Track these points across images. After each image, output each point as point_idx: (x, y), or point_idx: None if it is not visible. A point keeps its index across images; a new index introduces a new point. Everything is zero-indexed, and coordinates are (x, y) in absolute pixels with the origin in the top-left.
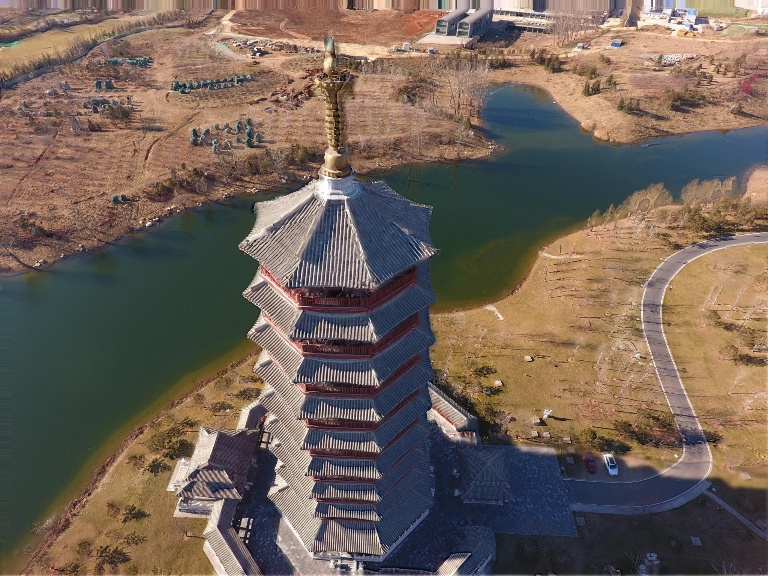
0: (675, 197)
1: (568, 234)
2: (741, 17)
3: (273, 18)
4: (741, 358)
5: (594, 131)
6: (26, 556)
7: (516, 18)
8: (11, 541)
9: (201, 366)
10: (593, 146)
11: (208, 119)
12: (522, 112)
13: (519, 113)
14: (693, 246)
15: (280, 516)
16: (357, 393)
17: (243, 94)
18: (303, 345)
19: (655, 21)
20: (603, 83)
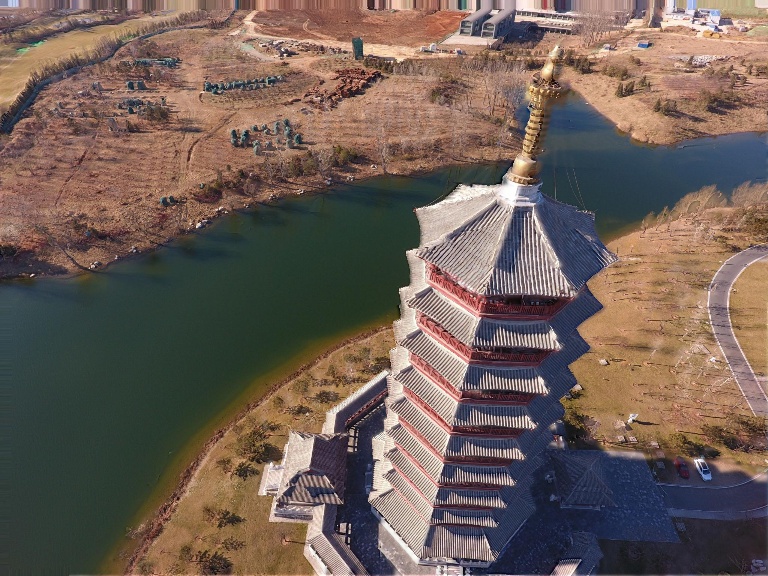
0: (722, 199)
1: (620, 236)
2: (765, 18)
3: (295, 18)
4: None
5: (631, 132)
6: (123, 561)
7: (538, 19)
8: (105, 546)
9: (271, 369)
10: (632, 148)
11: (245, 120)
12: (556, 113)
13: (553, 114)
14: (751, 249)
15: (378, 521)
16: (512, 400)
17: (276, 95)
18: (473, 352)
19: (678, 22)
20: (636, 84)
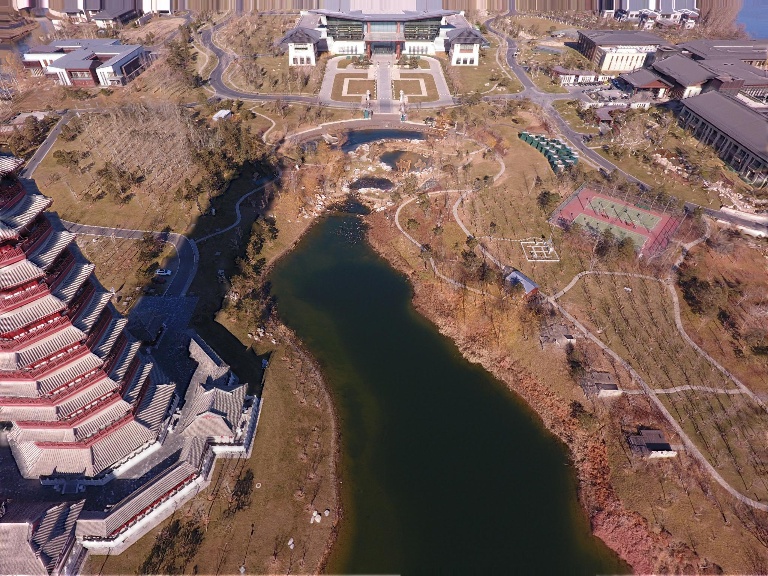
0: None
1: None
2: None
3: None
4: (125, 200)
5: None
6: None
7: None
8: None
9: None
10: None
11: None
12: None
13: None
14: None
15: (115, 479)
16: (69, 264)
17: None
18: (20, 246)
19: None
20: None
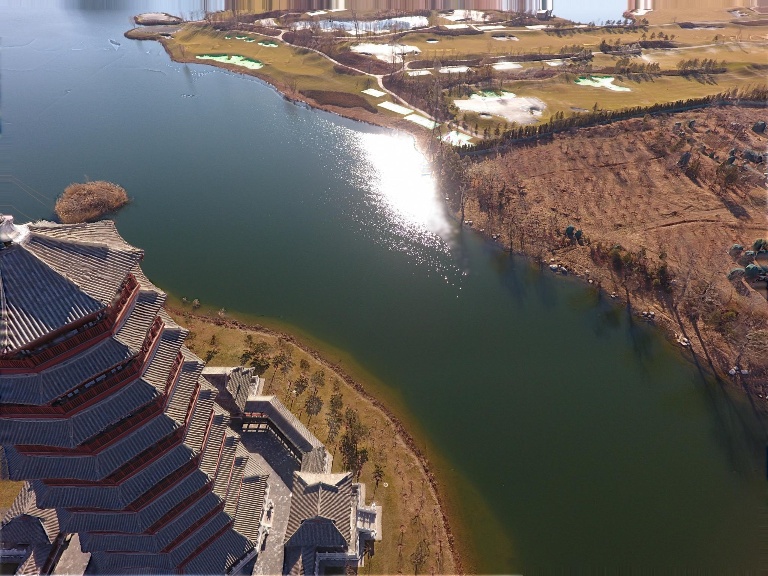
0: None
1: None
2: None
3: None
4: None
5: None
6: (206, 313)
7: None
8: (220, 304)
9: (360, 362)
10: None
11: None
12: None
13: None
14: None
15: None
16: None
17: None
18: None
19: None
20: None
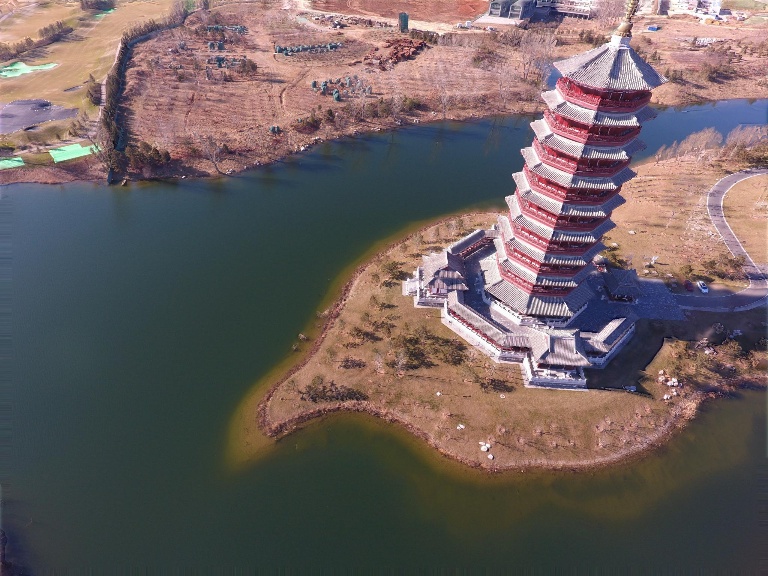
0: (718, 144)
1: (639, 165)
2: (760, 10)
3: None
4: None
5: None
6: (319, 328)
7: (557, 5)
8: (302, 322)
9: (386, 237)
10: None
11: (319, 75)
12: None
13: None
14: (740, 172)
15: (489, 306)
16: (604, 173)
17: (340, 57)
18: (589, 135)
19: (683, 11)
20: (648, 58)
